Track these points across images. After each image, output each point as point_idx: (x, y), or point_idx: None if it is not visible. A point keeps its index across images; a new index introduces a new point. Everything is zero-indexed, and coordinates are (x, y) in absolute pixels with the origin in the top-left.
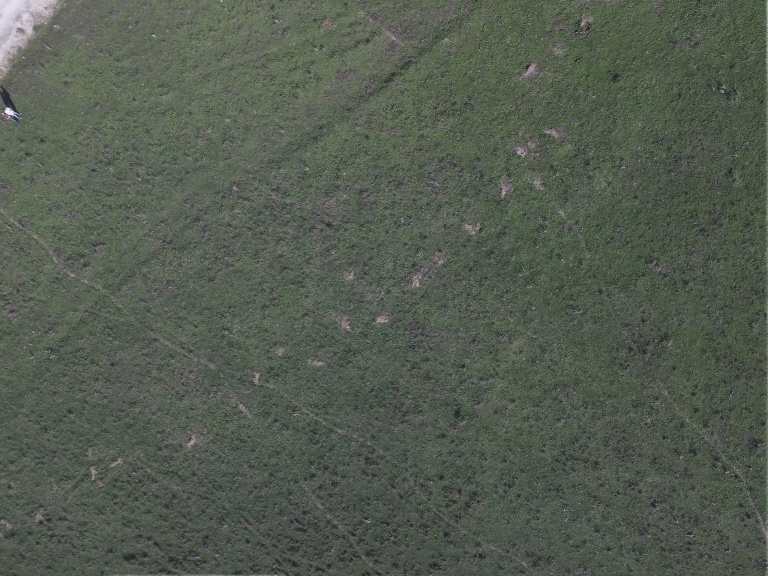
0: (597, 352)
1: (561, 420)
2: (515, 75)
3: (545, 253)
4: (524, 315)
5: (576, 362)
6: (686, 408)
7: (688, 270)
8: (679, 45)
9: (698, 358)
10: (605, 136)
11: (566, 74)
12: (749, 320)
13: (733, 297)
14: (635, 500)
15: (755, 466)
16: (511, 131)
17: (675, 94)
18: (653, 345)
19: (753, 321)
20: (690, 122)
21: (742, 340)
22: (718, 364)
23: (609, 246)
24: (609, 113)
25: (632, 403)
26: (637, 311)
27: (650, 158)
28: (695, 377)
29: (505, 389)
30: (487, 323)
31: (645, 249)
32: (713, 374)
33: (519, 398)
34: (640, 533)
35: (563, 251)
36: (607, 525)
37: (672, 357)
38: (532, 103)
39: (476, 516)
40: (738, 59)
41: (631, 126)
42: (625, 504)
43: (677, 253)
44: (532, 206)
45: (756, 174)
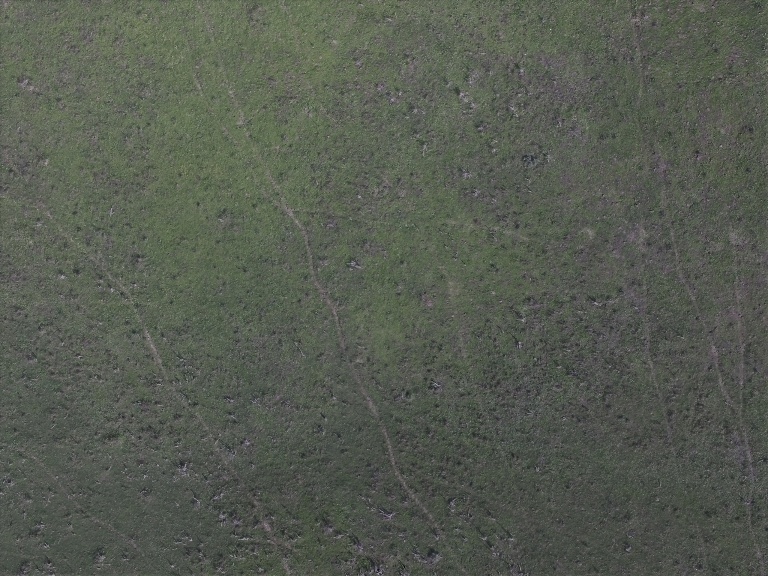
0: None
1: None
2: None
3: None
4: None
5: None
6: (70, 228)
7: (61, 87)
8: None
9: (77, 176)
10: None
11: None
12: (124, 134)
13: (108, 112)
14: (22, 325)
15: (140, 282)
16: None
17: None
18: (33, 166)
19: (127, 135)
20: None
21: (118, 155)
22: (97, 181)
23: None
24: None
25: (14, 226)
26: (15, 132)
27: None
28: (75, 195)
29: None
30: None
31: (18, 69)
32: (93, 191)
33: None
34: (27, 358)
35: None
36: None
37: (51, 176)
38: None
39: None
40: None
41: None
42: (13, 330)
43: (49, 71)
44: None
45: None
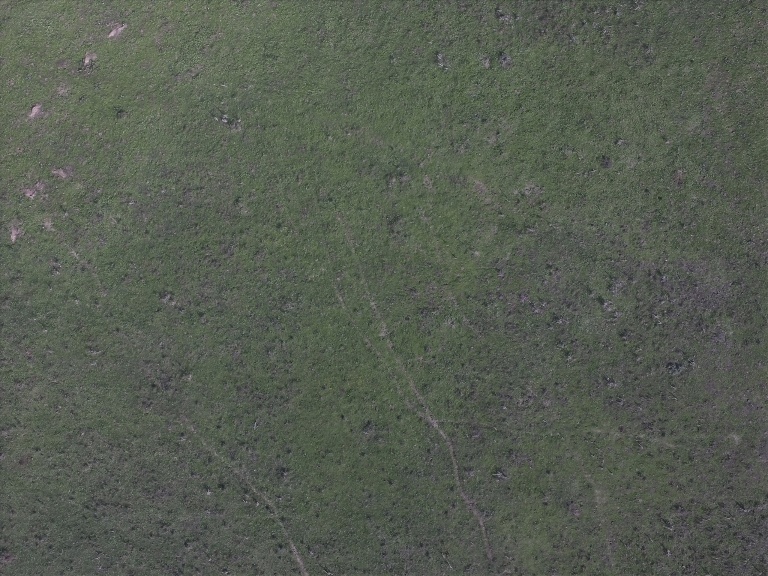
0: (119, 392)
1: (88, 465)
2: (21, 117)
3: (61, 295)
4: (43, 360)
5: (99, 404)
6: (213, 442)
7: (203, 302)
8: (182, 77)
9: (220, 390)
10: (112, 173)
11: (71, 113)
12: (266, 348)
13: (250, 326)
14: (168, 541)
15: (285, 495)
16: (19, 173)
17: (180, 126)
18: (175, 380)
19: (270, 349)
20: (196, 153)
21: (261, 368)
22: (240, 395)
23: (124, 283)
24: (116, 149)
25: (158, 441)
26: (157, 347)
27: (159, 192)
28: (219, 410)
29: (29, 438)
30: (5, 371)
31: (159, 284)
32: (236, 405)
33: (44, 446)
34: (174, 575)
35: (79, 291)
36: (142, 569)
37: (194, 391)
38: (39, 144)
39: (8, 572)
40: (239, 88)
41: (138, 161)
42: (159, 546)
43: (191, 285)
44: (43, 248)
45: (263, 201)
